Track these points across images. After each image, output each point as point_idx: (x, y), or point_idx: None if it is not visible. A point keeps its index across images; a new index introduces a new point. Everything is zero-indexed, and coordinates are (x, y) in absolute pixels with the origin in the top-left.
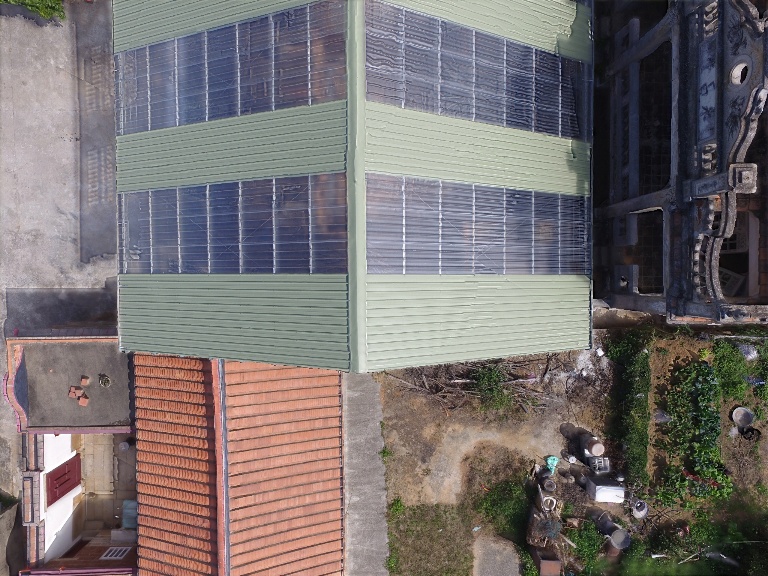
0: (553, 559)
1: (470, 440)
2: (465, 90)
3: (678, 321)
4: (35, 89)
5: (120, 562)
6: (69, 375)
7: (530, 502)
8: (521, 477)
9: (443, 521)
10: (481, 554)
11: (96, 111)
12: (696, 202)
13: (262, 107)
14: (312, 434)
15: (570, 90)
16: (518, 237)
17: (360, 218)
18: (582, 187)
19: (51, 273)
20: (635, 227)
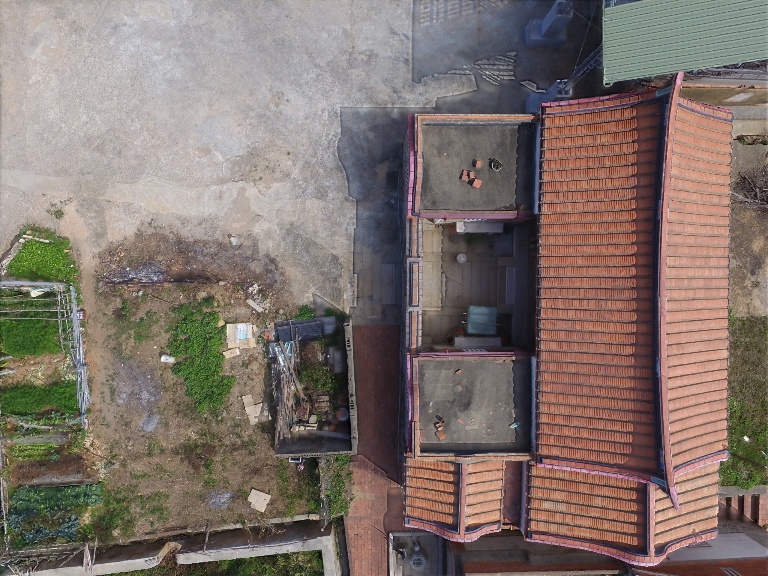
0: None
1: None
2: None
3: None
4: None
5: None
6: (461, 159)
7: None
8: None
9: None
10: None
11: None
12: None
13: None
14: (711, 209)
15: None
16: None
17: None
18: None
19: (384, 92)
20: None
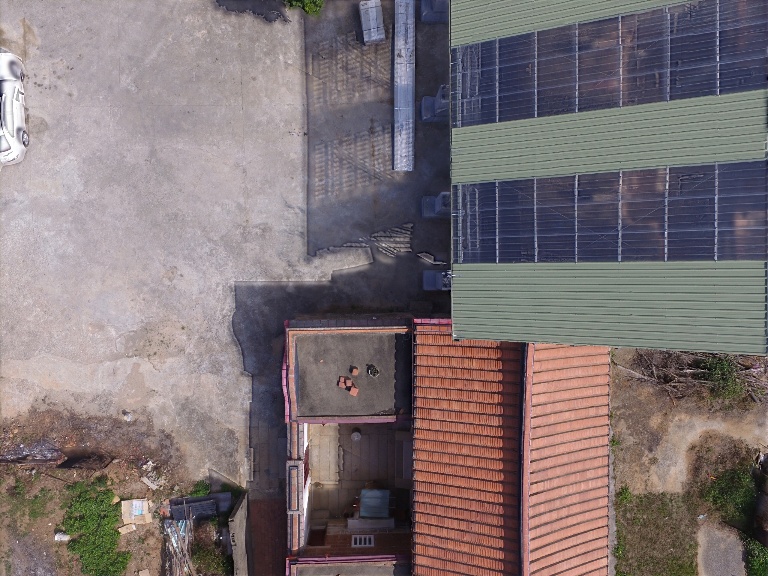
0: None
1: (696, 429)
2: None
3: None
4: (264, 84)
5: (375, 549)
6: (338, 365)
7: (758, 490)
8: (747, 465)
9: (669, 509)
10: (705, 541)
11: (323, 106)
12: None
13: (652, 97)
14: (587, 422)
15: None
16: None
17: None
18: None
19: (279, 266)
20: None
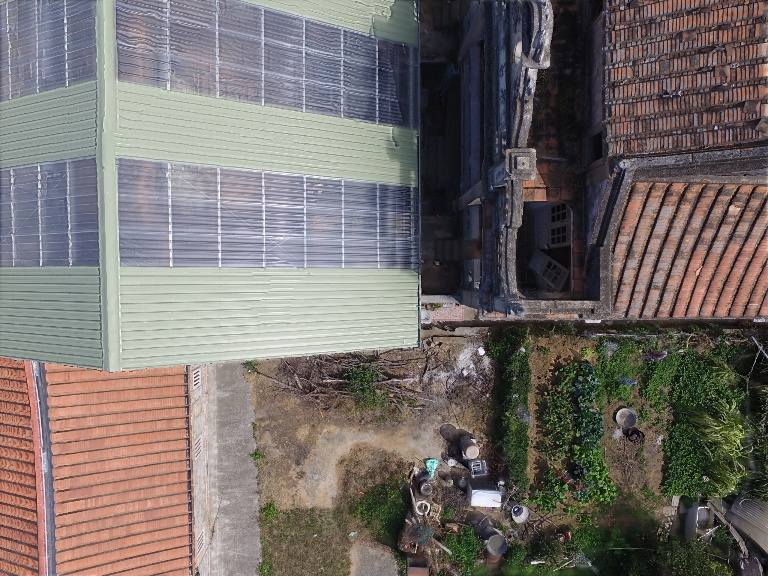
0: (421, 566)
1: (346, 442)
2: (252, 72)
3: (491, 318)
4: None
5: None
6: None
7: (406, 506)
8: (398, 480)
9: (318, 526)
10: (358, 560)
11: None
12: (499, 191)
13: (29, 90)
14: (154, 436)
15: (390, 74)
16: (323, 229)
17: (109, 206)
18: (407, 177)
19: None
20: (476, 220)
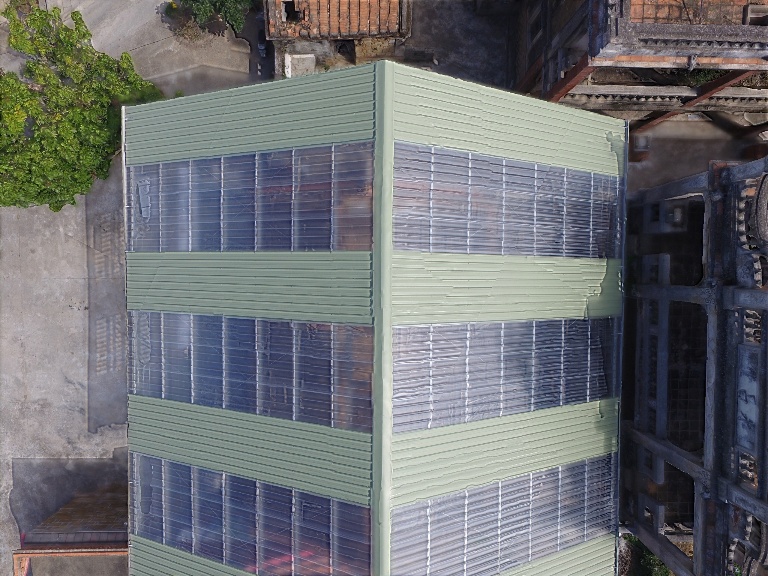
0: None
1: None
2: (493, 386)
3: None
4: (43, 257)
5: None
6: None
7: None
8: None
9: None
10: None
11: (105, 279)
12: None
13: (282, 413)
14: None
15: (599, 350)
16: (544, 518)
17: (384, 561)
18: (609, 444)
19: (58, 443)
20: (662, 467)
